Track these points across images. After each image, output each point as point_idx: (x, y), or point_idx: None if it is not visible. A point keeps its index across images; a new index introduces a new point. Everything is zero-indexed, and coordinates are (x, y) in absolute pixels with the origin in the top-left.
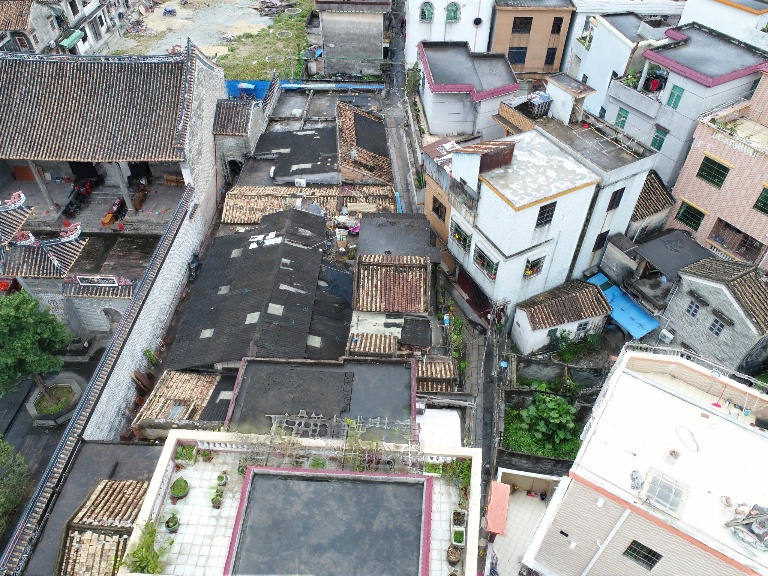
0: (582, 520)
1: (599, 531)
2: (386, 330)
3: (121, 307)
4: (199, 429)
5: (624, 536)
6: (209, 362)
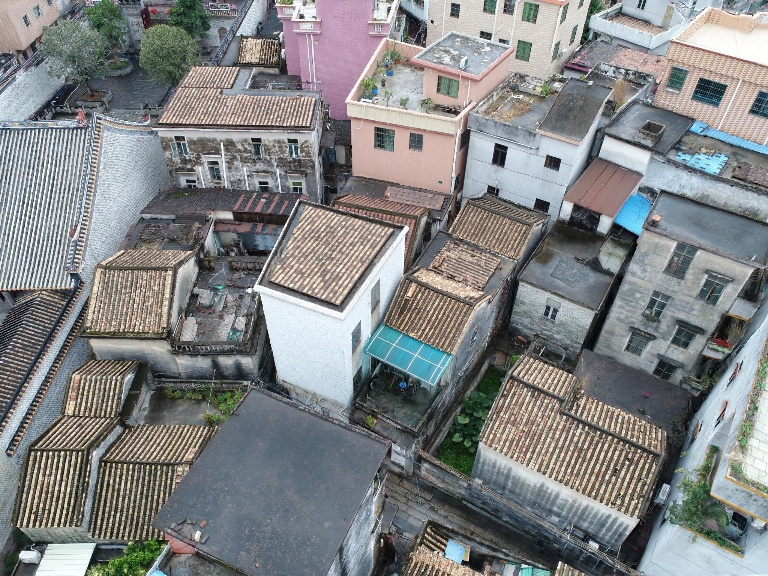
0: (436, 6)
1: (442, 8)
2: None
3: (229, 26)
4: None
5: (448, 3)
6: None
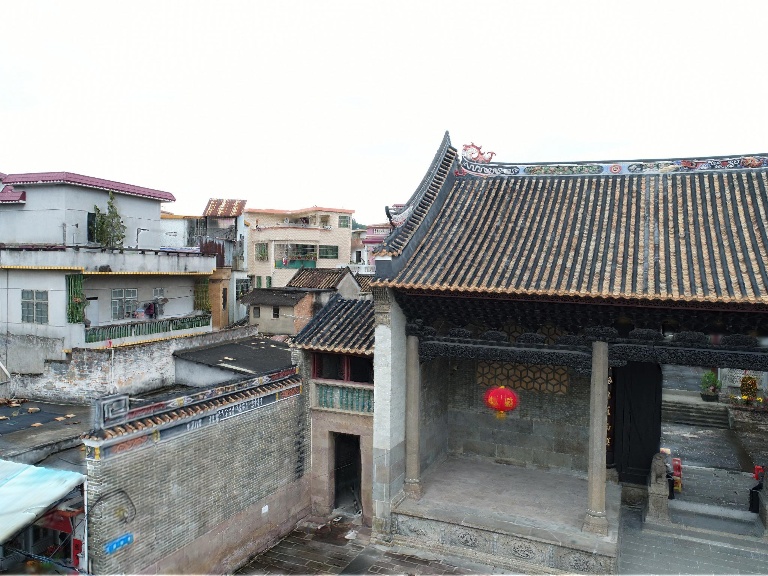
0: None
1: None
2: None
3: None
4: None
5: None
6: None
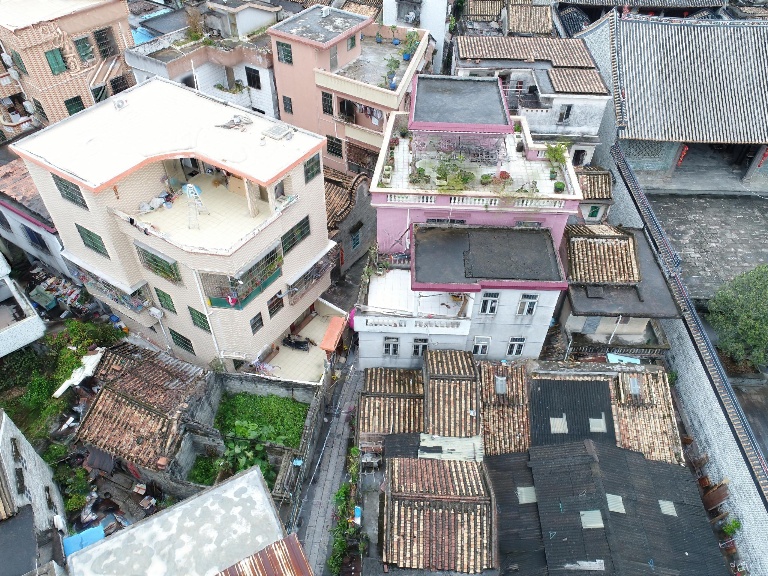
0: None
1: None
2: (439, 442)
3: None
4: (600, 363)
5: None
6: (637, 453)
